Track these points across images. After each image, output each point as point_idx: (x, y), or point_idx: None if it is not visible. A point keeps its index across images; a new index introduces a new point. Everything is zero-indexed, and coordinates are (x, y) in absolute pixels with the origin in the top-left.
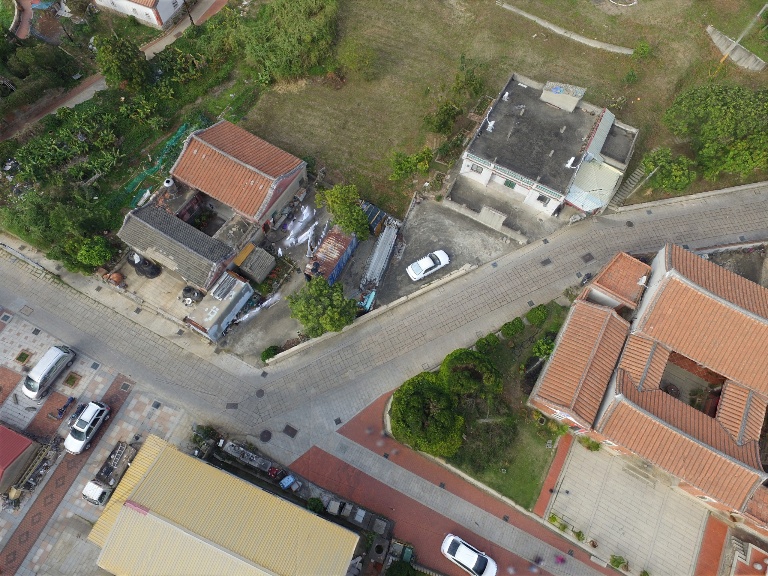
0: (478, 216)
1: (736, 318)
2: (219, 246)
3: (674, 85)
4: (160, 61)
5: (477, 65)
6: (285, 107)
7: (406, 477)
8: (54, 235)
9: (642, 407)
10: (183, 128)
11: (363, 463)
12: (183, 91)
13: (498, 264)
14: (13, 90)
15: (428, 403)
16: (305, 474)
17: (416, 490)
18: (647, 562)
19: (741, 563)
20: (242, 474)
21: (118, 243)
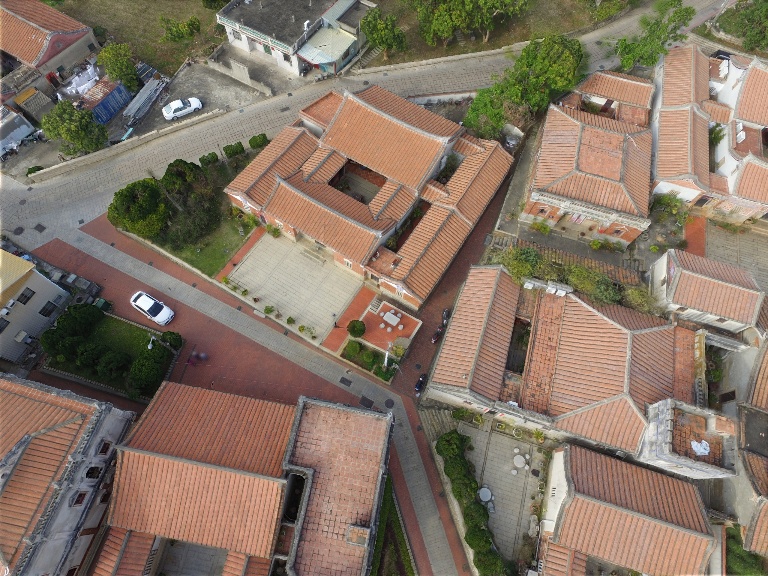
0: (233, 73)
1: (395, 129)
2: (0, 86)
3: None
4: None
5: None
6: None
7: (124, 258)
8: None
9: (299, 189)
10: None
11: (92, 250)
12: None
13: (244, 110)
14: None
15: (137, 193)
16: (43, 257)
17: (129, 267)
18: (299, 315)
19: (370, 313)
20: None
21: None
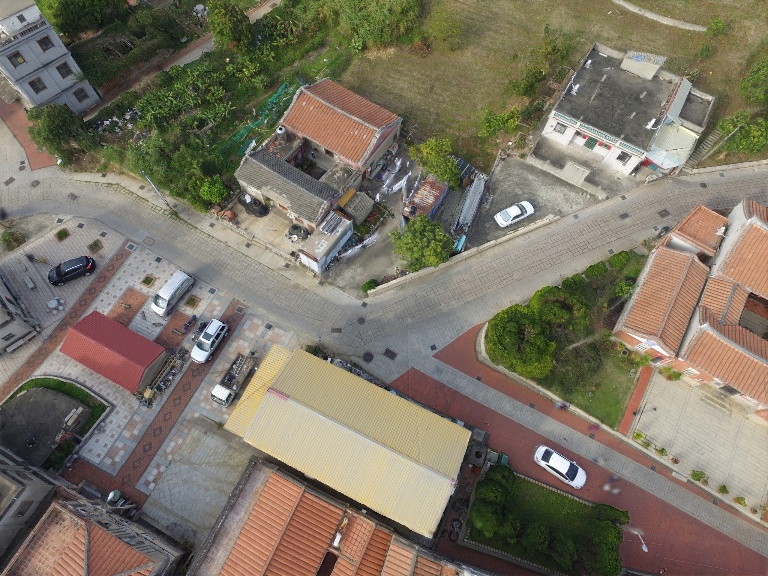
0: (561, 172)
1: None
2: (326, 188)
3: (746, 60)
4: (261, 27)
5: (561, 35)
6: (376, 71)
7: (498, 397)
8: (174, 175)
9: (725, 337)
10: (283, 87)
11: (458, 384)
12: (282, 55)
13: (579, 216)
14: (132, 48)
15: (523, 329)
16: (405, 391)
17: (508, 409)
18: (725, 480)
19: None
20: None
21: (229, 185)
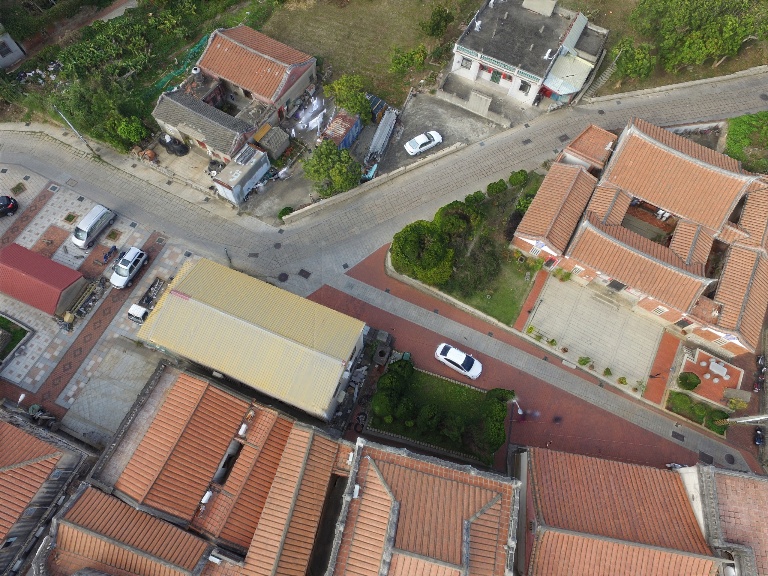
0: (467, 104)
1: (687, 166)
2: (241, 123)
3: None
4: None
5: None
6: (296, 21)
7: (405, 306)
8: (95, 119)
9: None
10: (205, 38)
11: (368, 296)
12: (204, 8)
13: (485, 143)
14: (54, 4)
15: (423, 238)
16: None
17: (413, 315)
18: (610, 364)
19: (689, 362)
20: None
21: (151, 128)
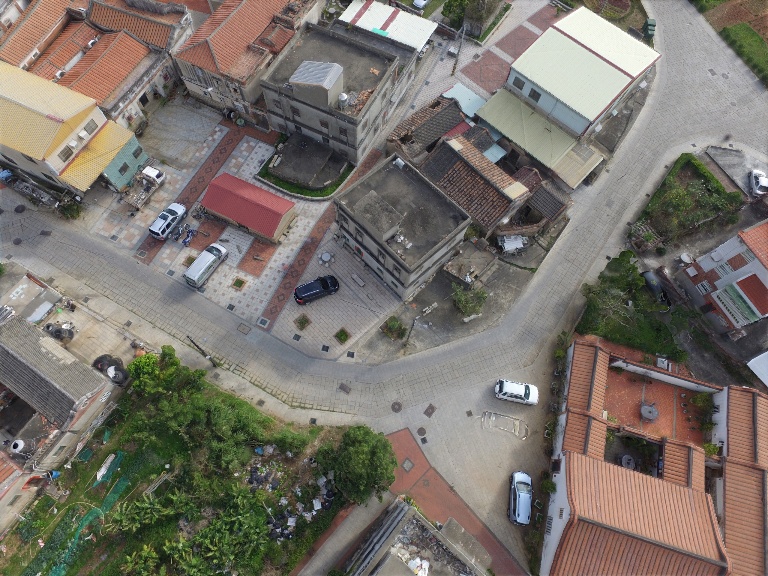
0: None
1: None
2: None
3: None
4: None
5: None
6: None
7: None
8: None
9: None
10: None
11: None
12: None
13: None
14: None
15: None
16: None
17: None
18: None
19: None
20: (46, 185)
21: (139, 398)
